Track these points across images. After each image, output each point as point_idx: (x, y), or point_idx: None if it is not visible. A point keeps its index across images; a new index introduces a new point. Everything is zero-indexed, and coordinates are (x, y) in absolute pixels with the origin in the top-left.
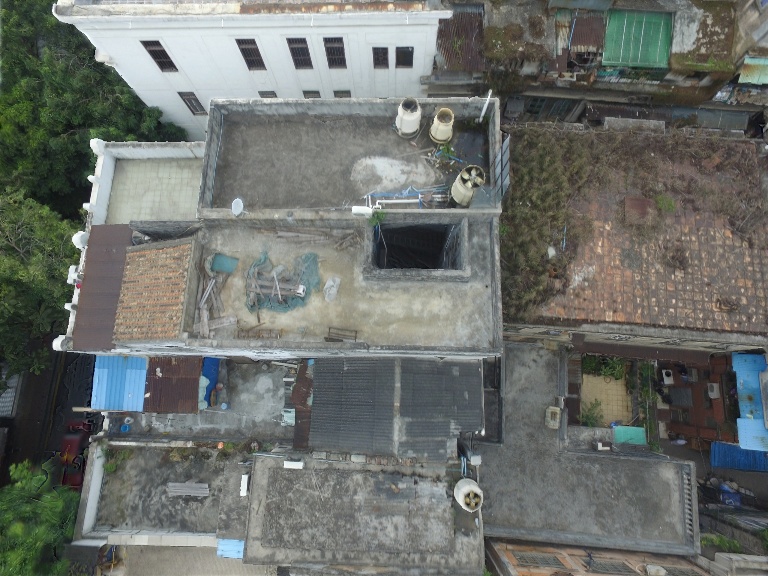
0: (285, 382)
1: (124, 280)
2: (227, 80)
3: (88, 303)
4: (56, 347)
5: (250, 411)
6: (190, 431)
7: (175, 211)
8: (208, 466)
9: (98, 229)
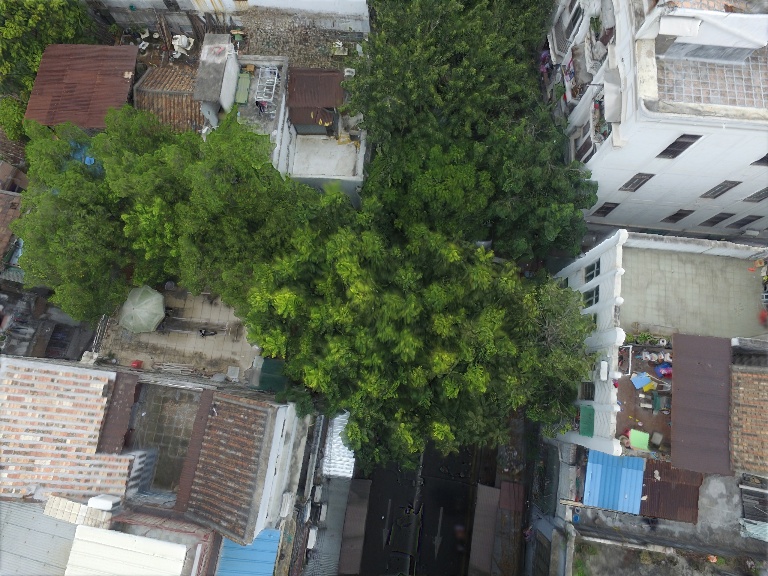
0: (743, 489)
1: (738, 402)
2: (709, 169)
3: (684, 419)
4: (617, 453)
5: (704, 516)
6: (641, 529)
7: (683, 309)
8: (674, 572)
9: (683, 338)
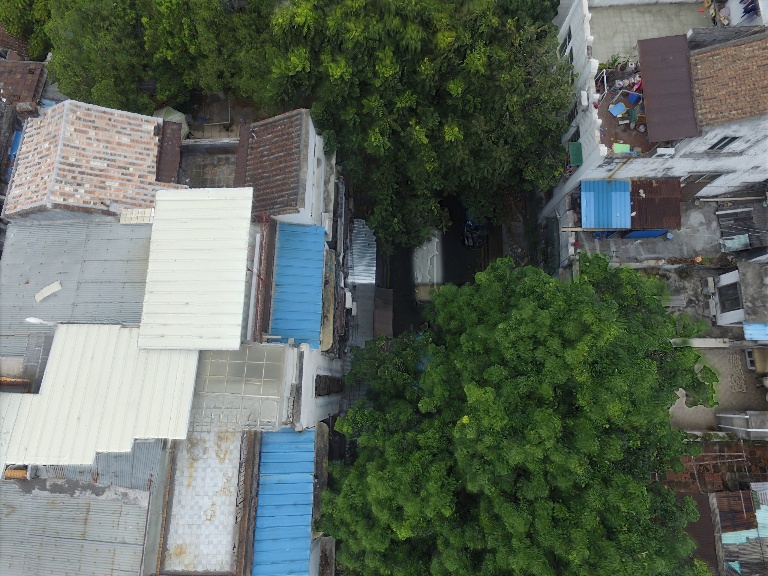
0: (719, 215)
1: (697, 78)
2: None
3: (655, 103)
4: (603, 152)
5: (689, 242)
6: (636, 261)
7: None
8: (668, 286)
9: (646, 43)
